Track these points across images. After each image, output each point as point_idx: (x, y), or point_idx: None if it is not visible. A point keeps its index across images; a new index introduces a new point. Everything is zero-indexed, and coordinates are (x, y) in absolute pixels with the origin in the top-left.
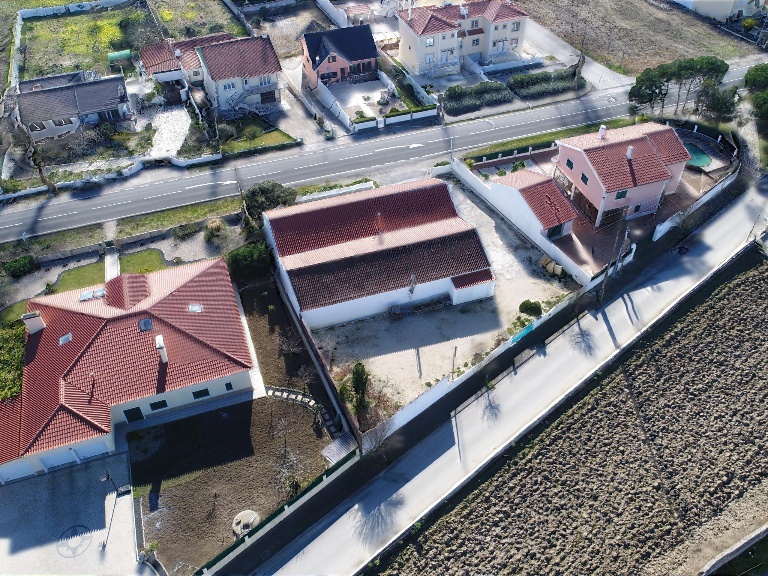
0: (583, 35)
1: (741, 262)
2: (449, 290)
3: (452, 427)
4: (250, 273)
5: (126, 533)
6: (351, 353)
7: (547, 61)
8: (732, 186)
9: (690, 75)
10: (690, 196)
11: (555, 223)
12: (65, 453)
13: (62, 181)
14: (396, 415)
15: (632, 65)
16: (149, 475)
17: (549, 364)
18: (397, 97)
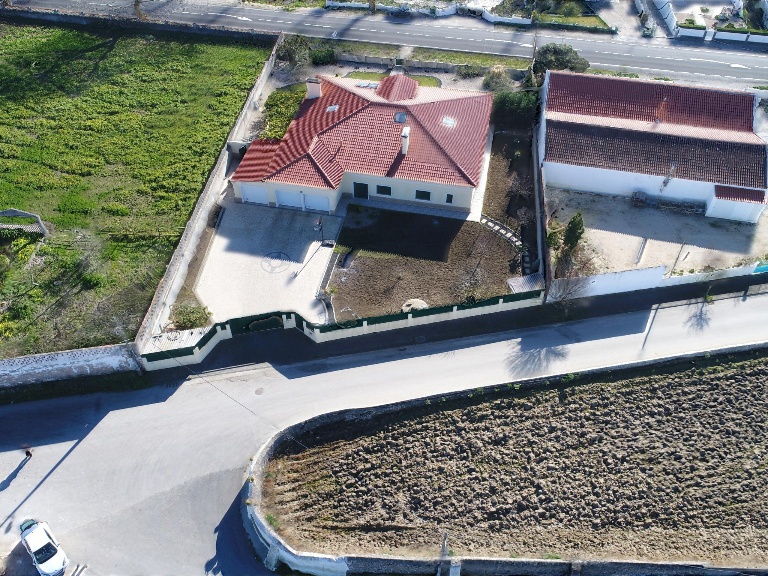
0: None
1: None
2: (707, 198)
3: (648, 316)
4: (511, 120)
5: (316, 274)
6: None
7: None
8: None
9: None
10: None
11: None
12: (296, 195)
13: (383, 5)
14: (595, 277)
15: None
16: (353, 241)
17: None
18: (740, 17)
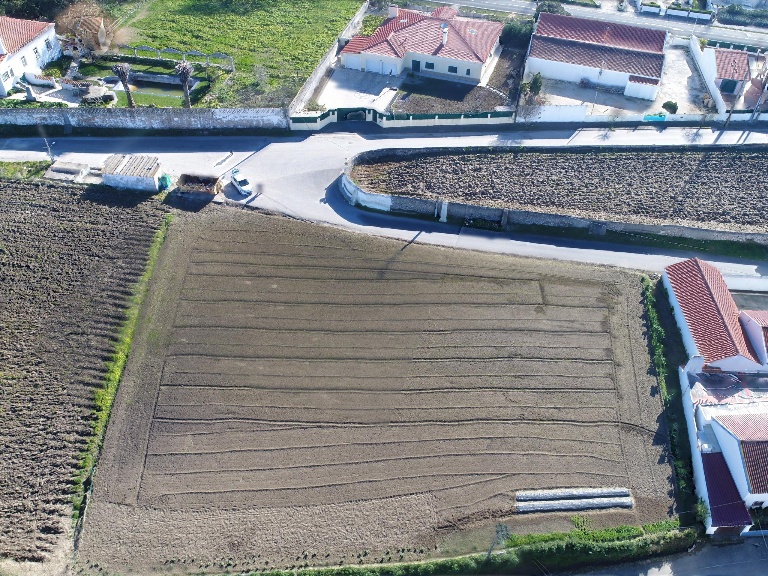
0: None
1: None
2: None
3: (574, 132)
4: (515, 42)
5: (386, 101)
6: (544, 89)
7: None
8: None
9: None
10: None
11: (728, 77)
12: (378, 64)
13: None
14: (545, 107)
15: None
16: (409, 89)
17: (659, 136)
18: (690, 4)
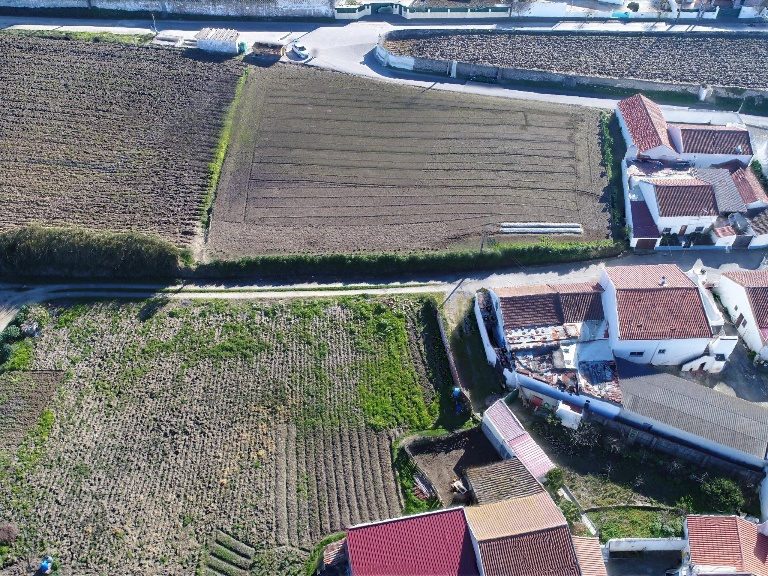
0: None
1: None
2: None
3: (557, 23)
4: None
5: (409, 2)
6: None
7: None
8: None
9: None
10: None
11: None
12: None
13: None
14: (534, 4)
15: None
16: None
17: (623, 27)
18: None
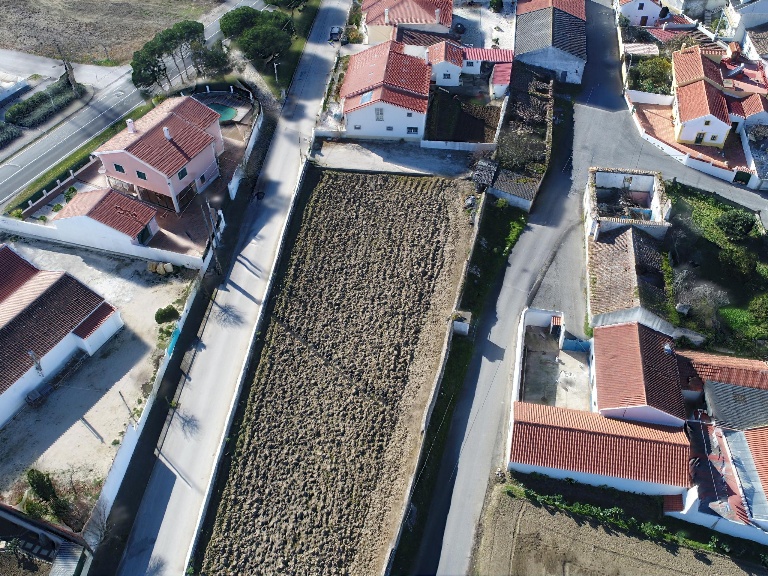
0: (53, 43)
1: (308, 182)
2: (77, 345)
3: (164, 464)
4: None
5: None
6: (13, 468)
7: (33, 81)
8: (265, 124)
9: (176, 44)
10: (238, 148)
11: (140, 228)
12: None
13: None
14: (103, 492)
15: (118, 55)
16: None
17: (213, 353)
18: None
